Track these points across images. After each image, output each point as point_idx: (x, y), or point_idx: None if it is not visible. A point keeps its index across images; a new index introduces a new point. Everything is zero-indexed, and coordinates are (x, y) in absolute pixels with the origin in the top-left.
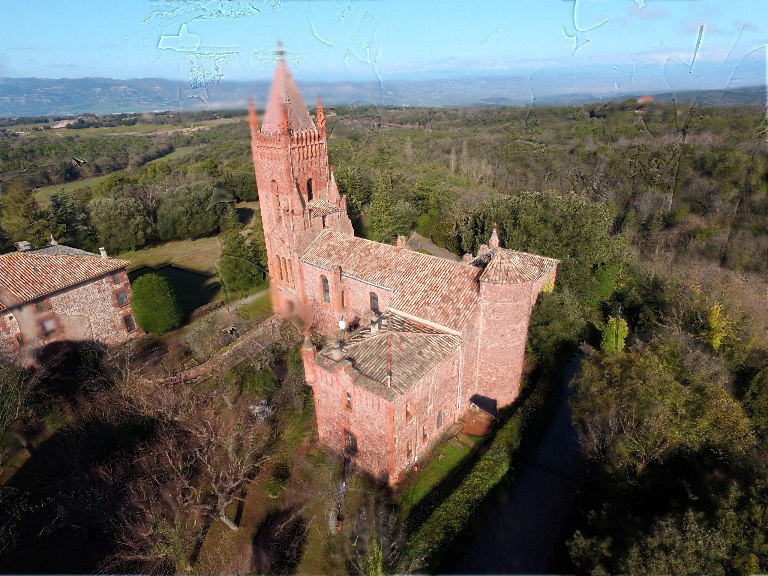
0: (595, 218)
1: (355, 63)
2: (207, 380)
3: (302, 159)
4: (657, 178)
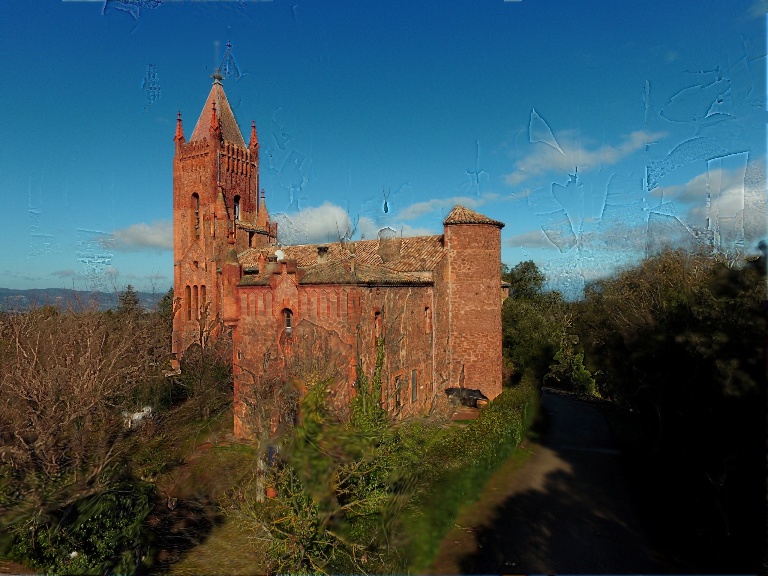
0: (530, 275)
1: (303, 11)
2: None
3: (231, 171)
4: (568, 283)
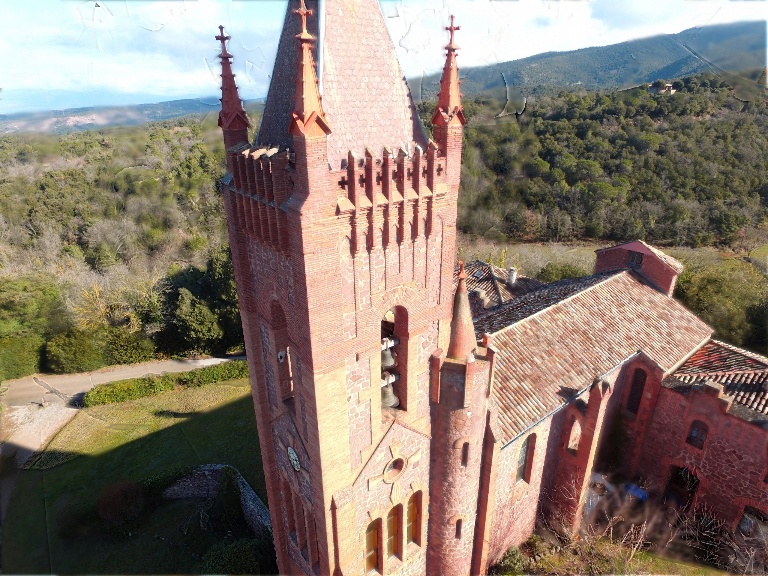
0: None
1: None
2: None
3: None
4: None
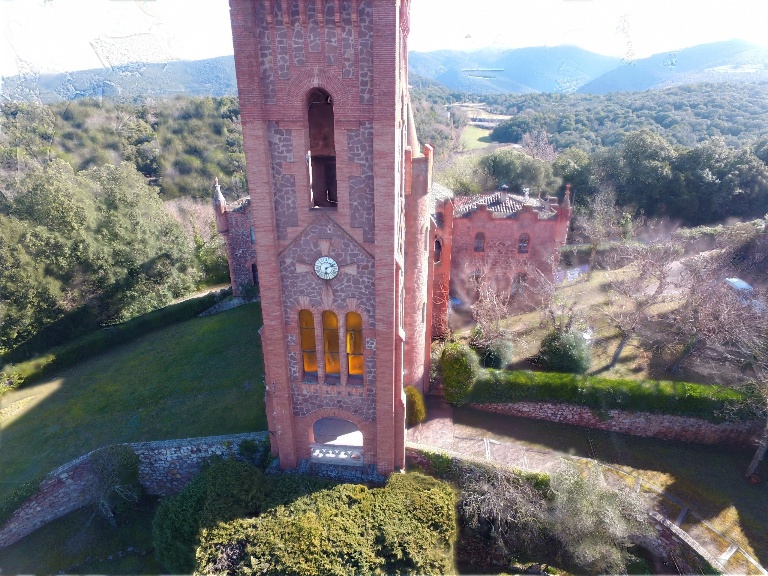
0: None
1: None
2: (635, 386)
3: None
4: None
